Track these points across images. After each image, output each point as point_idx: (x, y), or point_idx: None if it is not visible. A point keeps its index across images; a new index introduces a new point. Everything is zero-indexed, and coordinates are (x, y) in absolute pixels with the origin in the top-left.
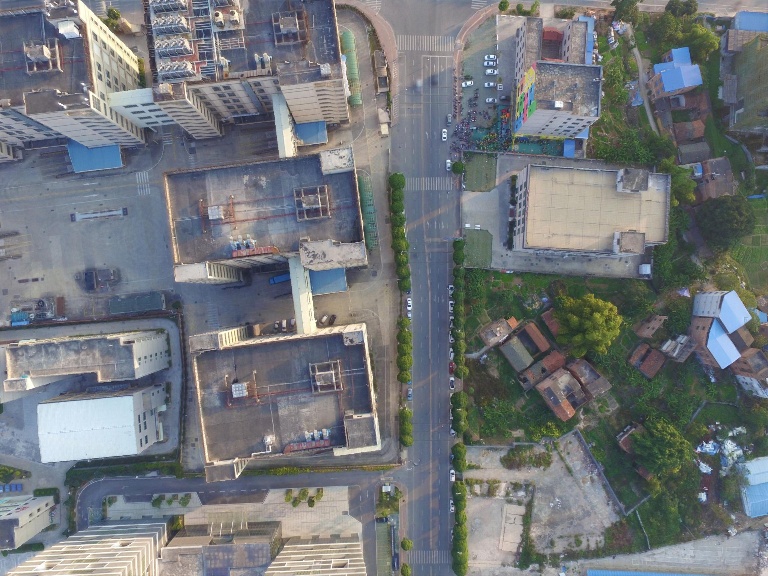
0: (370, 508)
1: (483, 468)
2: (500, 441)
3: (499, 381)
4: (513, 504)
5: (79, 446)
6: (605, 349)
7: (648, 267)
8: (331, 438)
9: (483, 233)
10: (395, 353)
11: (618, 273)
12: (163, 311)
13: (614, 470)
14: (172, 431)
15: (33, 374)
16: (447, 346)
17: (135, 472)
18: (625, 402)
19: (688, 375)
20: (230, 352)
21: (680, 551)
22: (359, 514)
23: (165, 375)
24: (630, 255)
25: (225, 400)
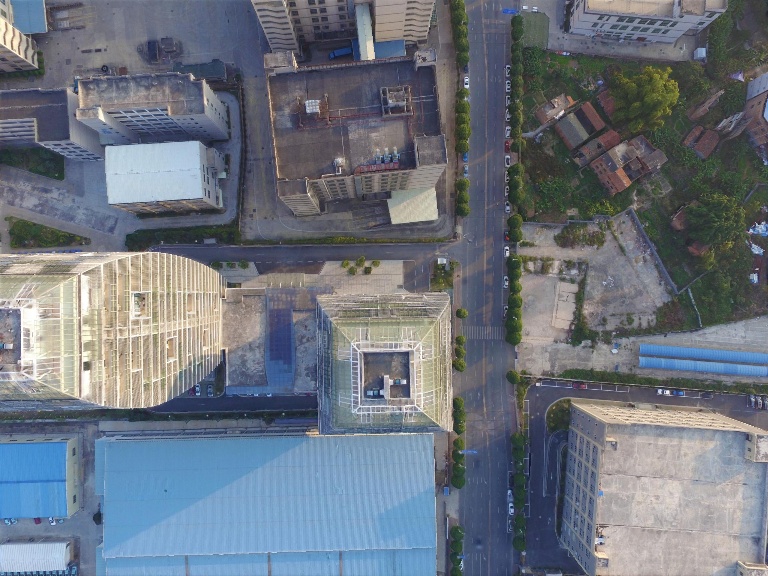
0: (425, 283)
1: (537, 246)
2: (554, 220)
3: (555, 158)
4: (566, 282)
5: (146, 188)
6: (662, 121)
7: (703, 50)
8: (400, 163)
9: (540, 16)
10: (452, 131)
11: (673, 59)
12: (224, 83)
13: (667, 250)
14: (230, 202)
15: (104, 108)
16: (503, 125)
17: (195, 236)
18: (678, 184)
19: (742, 153)
20: (302, 76)
21: (731, 331)
22: (414, 288)
23: (224, 147)
24: (688, 27)
25: (297, 122)
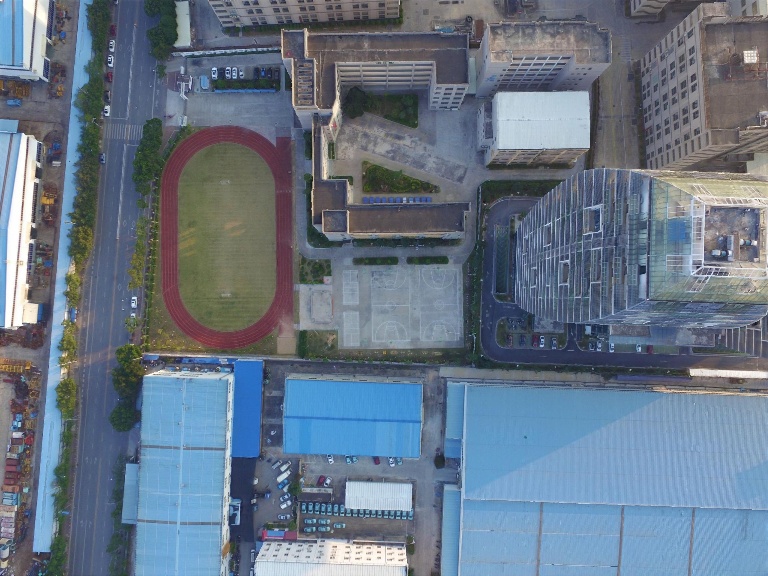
0: None
1: None
2: None
3: None
4: None
5: (535, 135)
6: None
7: None
8: None
9: None
10: None
11: None
12: None
13: None
14: (578, 158)
15: None
16: None
17: (551, 188)
18: None
19: None
20: (730, 28)
21: None
22: None
23: None
24: None
25: (725, 72)
